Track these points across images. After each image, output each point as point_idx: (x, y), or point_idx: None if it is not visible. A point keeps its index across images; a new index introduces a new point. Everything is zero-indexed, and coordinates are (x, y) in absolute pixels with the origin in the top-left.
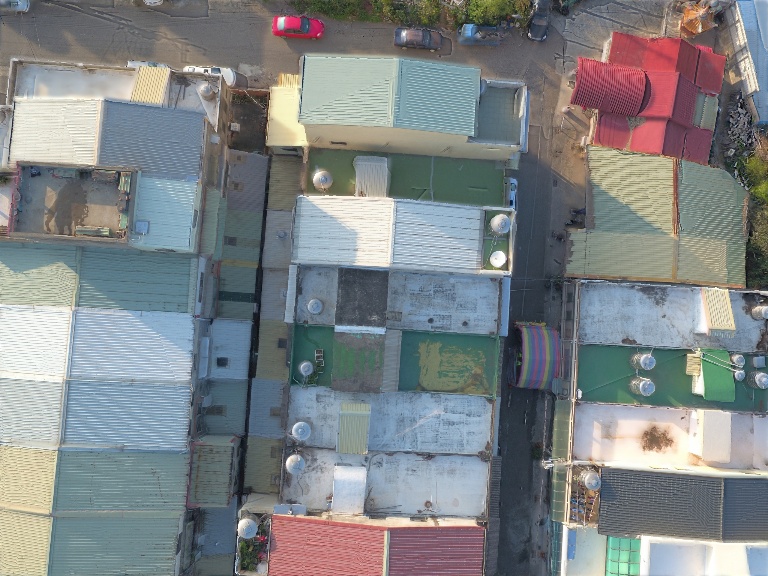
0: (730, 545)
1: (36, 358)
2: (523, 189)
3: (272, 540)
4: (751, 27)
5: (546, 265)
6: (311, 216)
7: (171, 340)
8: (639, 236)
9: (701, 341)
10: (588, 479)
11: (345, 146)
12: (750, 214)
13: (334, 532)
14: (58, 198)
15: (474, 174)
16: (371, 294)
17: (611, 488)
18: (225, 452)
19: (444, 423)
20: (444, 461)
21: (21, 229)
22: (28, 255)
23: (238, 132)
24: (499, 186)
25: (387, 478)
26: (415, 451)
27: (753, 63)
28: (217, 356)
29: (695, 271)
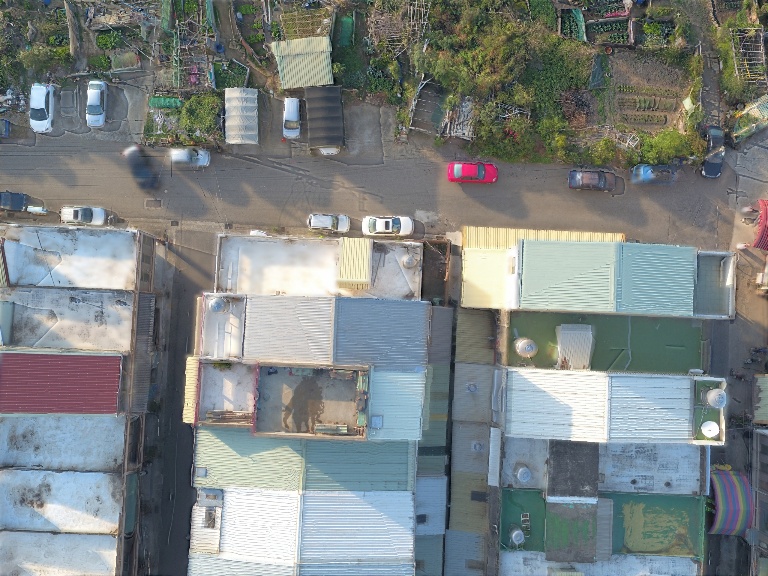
0: None
1: (265, 541)
2: None
3: None
4: None
5: None
6: (524, 390)
7: (393, 518)
8: None
9: None
10: None
11: None
12: None
13: None
14: (295, 395)
15: (671, 333)
16: (582, 464)
17: None
18: None
19: None
20: None
21: (260, 427)
22: (254, 439)
23: None
24: (696, 344)
25: None
26: None
27: None
28: (416, 514)
29: None
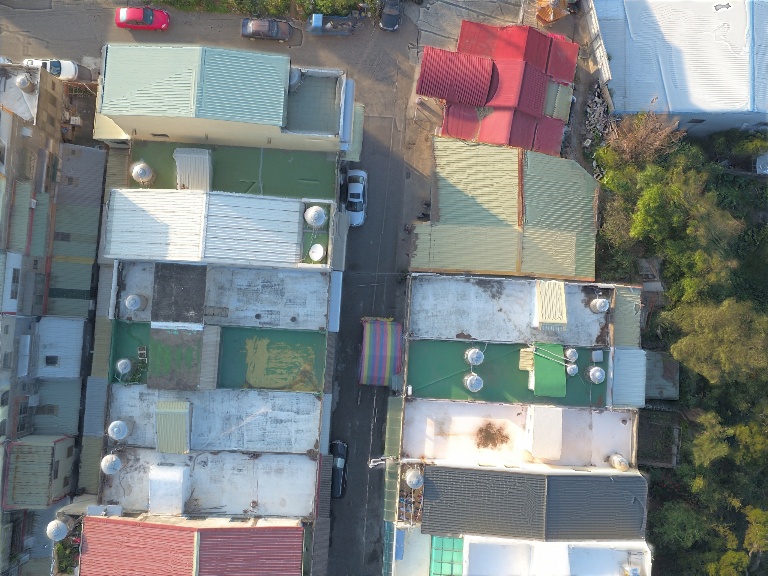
0: (551, 544)
1: None
2: (375, 182)
3: (84, 542)
4: (619, 15)
5: (398, 259)
6: (124, 210)
7: None
8: (485, 228)
9: (538, 335)
10: (410, 477)
11: (170, 138)
12: (601, 205)
13: (145, 533)
14: None
15: (304, 166)
16: (188, 289)
17: (434, 486)
18: (45, 452)
19: (272, 421)
20: (271, 460)
21: None
22: None
23: (80, 126)
24: (330, 178)
25: (212, 478)
26: (240, 450)
27: (605, 51)
28: (46, 354)
29: (540, 264)
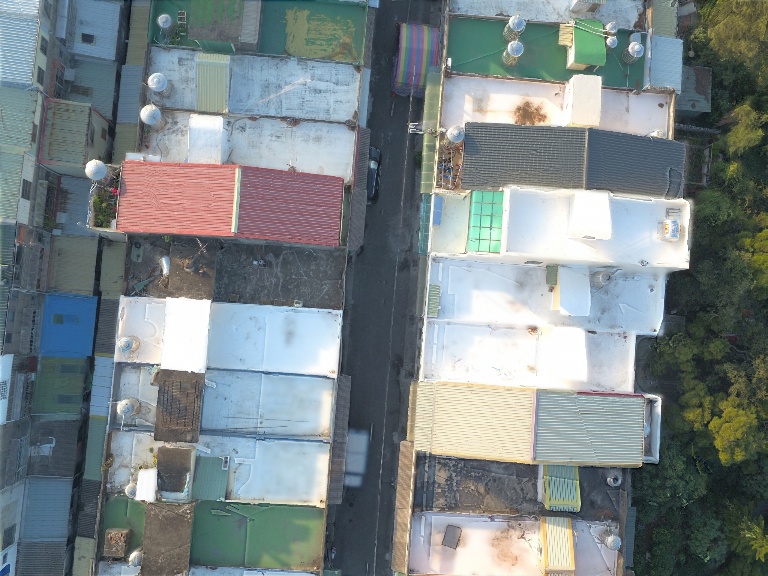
0: (592, 191)
1: None
2: None
3: (122, 185)
4: None
5: None
6: None
7: None
8: None
9: None
10: (451, 131)
11: None
12: None
13: (185, 173)
14: None
15: None
16: None
17: (474, 142)
18: (82, 112)
19: (310, 91)
20: (309, 128)
21: None
22: None
23: None
24: None
25: (250, 143)
26: (279, 116)
27: None
28: (82, 31)
29: None
